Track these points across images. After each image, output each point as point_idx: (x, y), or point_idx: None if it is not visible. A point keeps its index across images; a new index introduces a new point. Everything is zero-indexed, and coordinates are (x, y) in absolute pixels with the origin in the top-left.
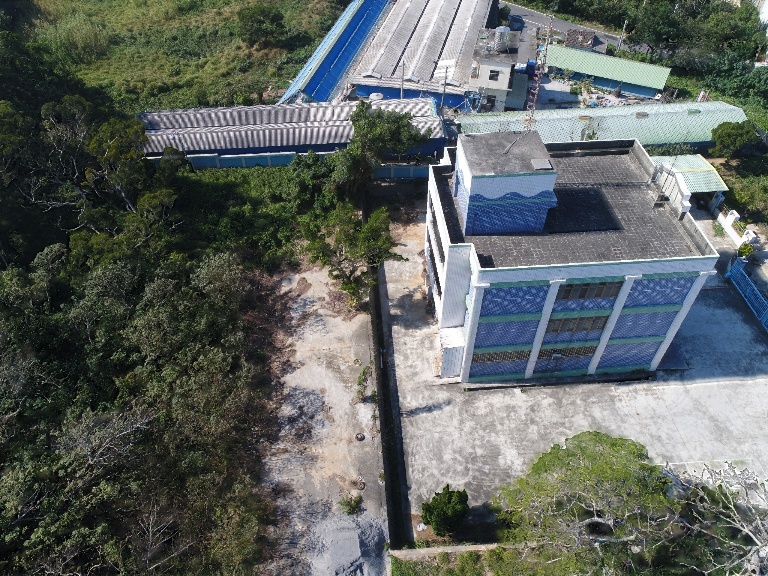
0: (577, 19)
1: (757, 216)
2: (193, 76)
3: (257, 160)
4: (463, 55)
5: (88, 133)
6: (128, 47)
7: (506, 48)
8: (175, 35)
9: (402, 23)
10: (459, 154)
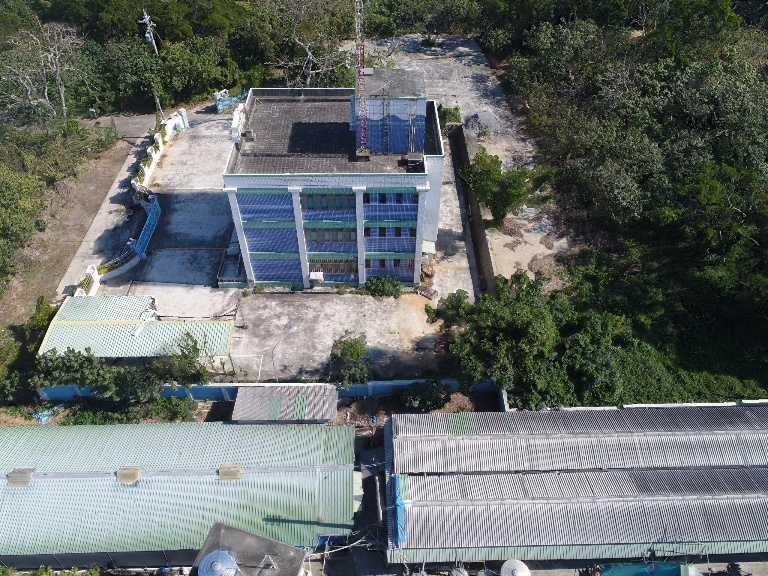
0: None
1: (24, 335)
2: None
3: None
4: None
5: None
6: None
7: None
8: None
9: None
10: None
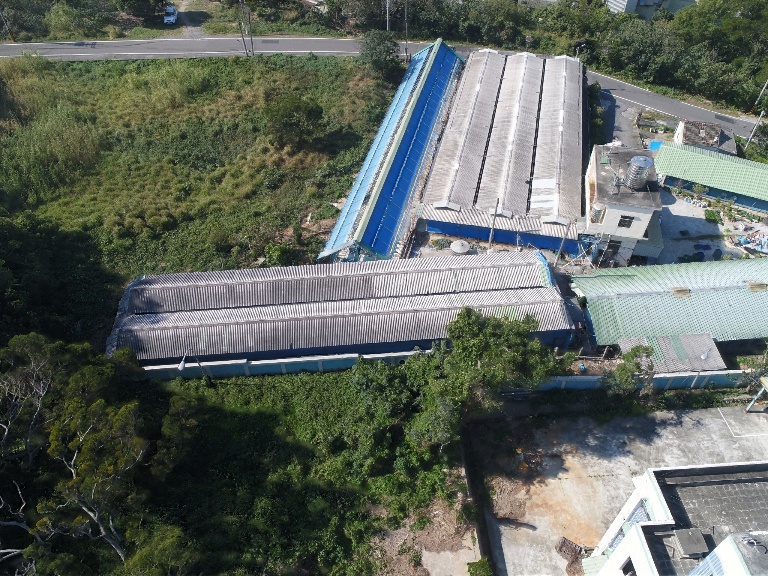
0: (677, 92)
1: None
2: (208, 200)
3: (303, 365)
4: (564, 171)
5: (52, 383)
6: (123, 153)
7: (643, 184)
8: (184, 131)
9: (475, 117)
10: (732, 573)
